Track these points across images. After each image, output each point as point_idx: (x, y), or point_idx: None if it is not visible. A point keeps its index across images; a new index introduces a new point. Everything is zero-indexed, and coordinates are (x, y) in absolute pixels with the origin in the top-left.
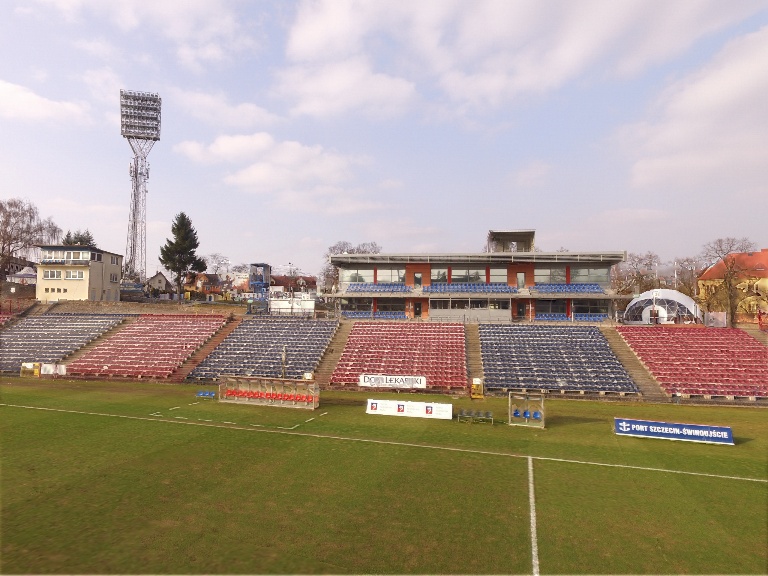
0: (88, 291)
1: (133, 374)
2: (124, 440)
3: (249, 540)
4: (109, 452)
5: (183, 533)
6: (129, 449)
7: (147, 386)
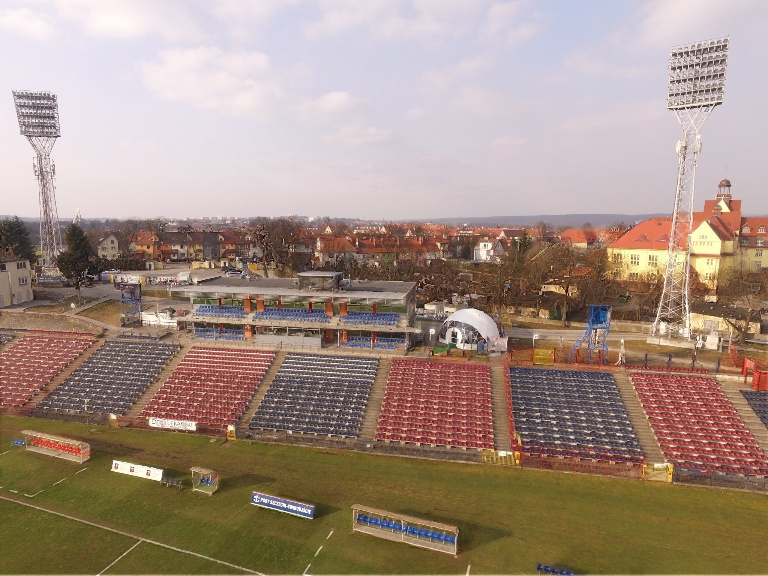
0: None
1: None
2: None
3: None
4: None
5: None
6: None
7: None
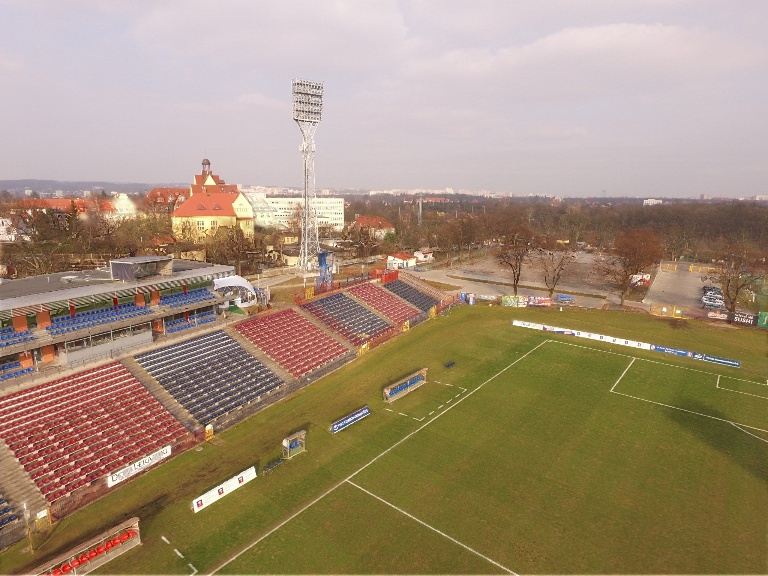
0: None
1: None
2: None
3: None
4: None
5: None
6: None
7: None
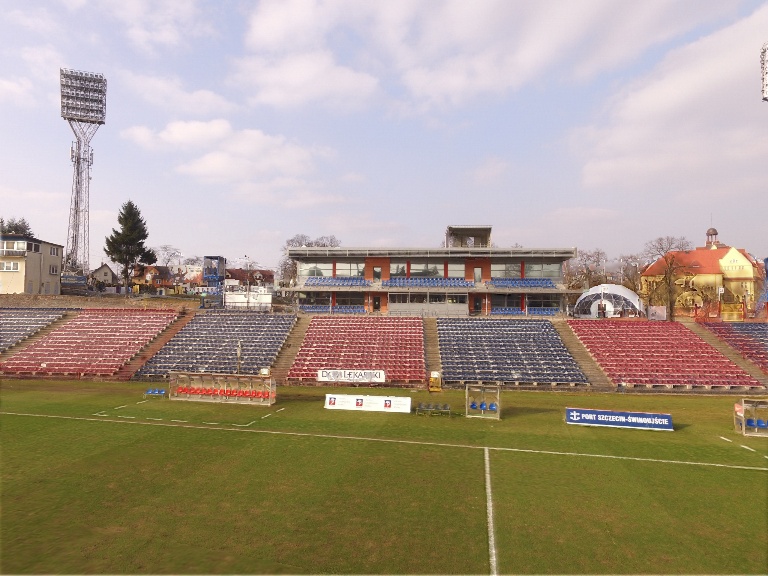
0: (24, 284)
1: (75, 372)
2: (63, 442)
3: (199, 543)
4: (46, 456)
5: (127, 539)
6: (68, 452)
7: (90, 384)
